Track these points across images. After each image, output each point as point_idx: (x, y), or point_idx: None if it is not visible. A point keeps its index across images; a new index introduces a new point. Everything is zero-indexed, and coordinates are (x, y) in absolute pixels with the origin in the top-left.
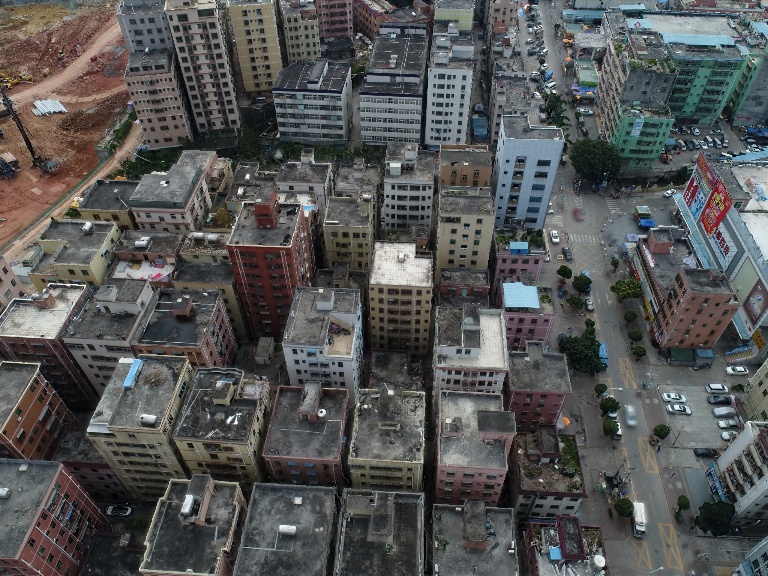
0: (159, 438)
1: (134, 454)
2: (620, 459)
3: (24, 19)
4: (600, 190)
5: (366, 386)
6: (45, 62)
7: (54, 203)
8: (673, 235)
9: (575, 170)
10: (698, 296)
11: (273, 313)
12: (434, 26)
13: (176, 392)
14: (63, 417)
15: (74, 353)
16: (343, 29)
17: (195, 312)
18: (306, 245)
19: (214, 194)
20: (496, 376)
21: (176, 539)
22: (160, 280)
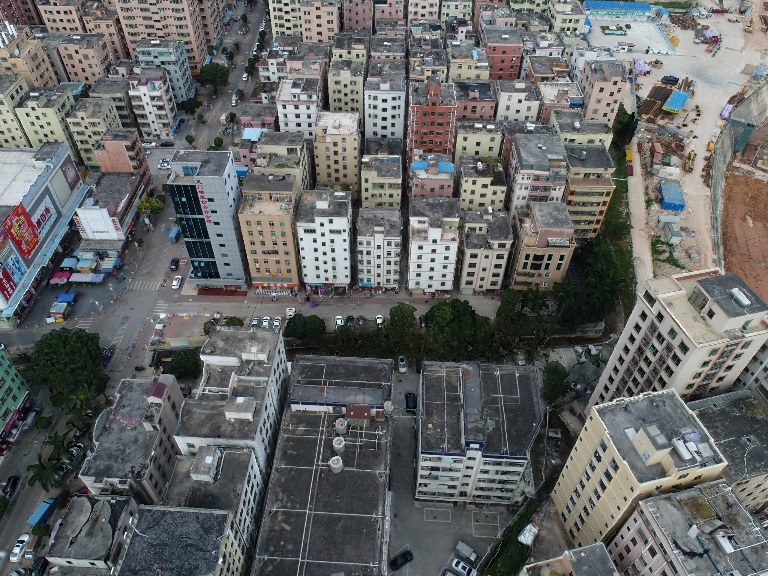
0: None
1: None
2: None
3: None
4: None
5: None
6: None
7: None
8: None
9: None
10: None
11: None
12: (243, 486)
13: None
14: None
15: None
16: None
17: None
18: None
19: None
20: None
21: (431, 43)
22: (506, 123)
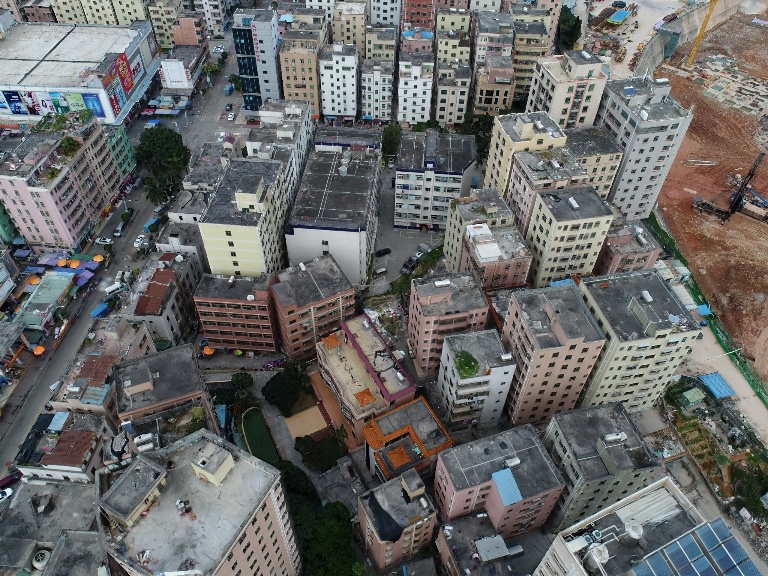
0: None
1: None
2: None
3: None
4: None
5: None
6: None
7: None
8: None
9: None
10: None
11: None
12: (288, 161)
13: None
14: None
15: None
16: None
17: None
18: None
19: None
20: None
21: None
22: None
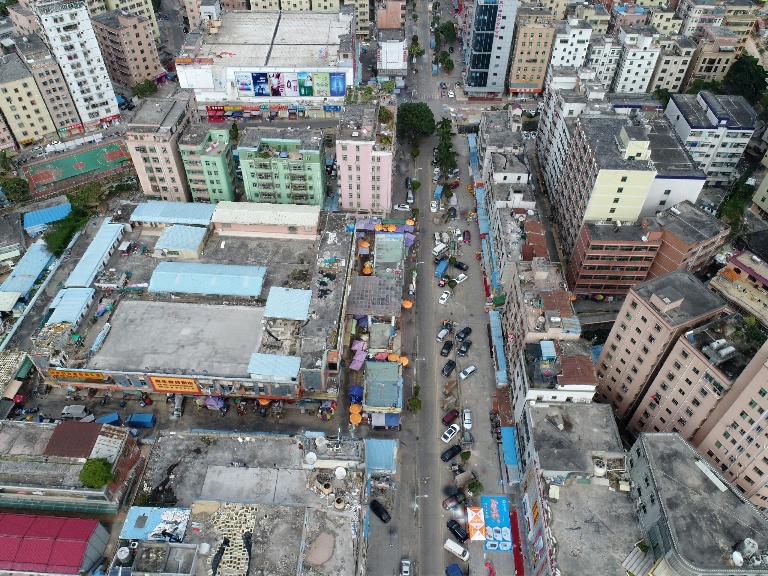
0: None
1: None
2: None
3: None
4: None
5: None
6: None
7: None
8: None
9: None
10: None
11: None
12: None
13: None
14: None
15: None
16: None
17: None
18: None
19: None
20: None
21: None
22: None
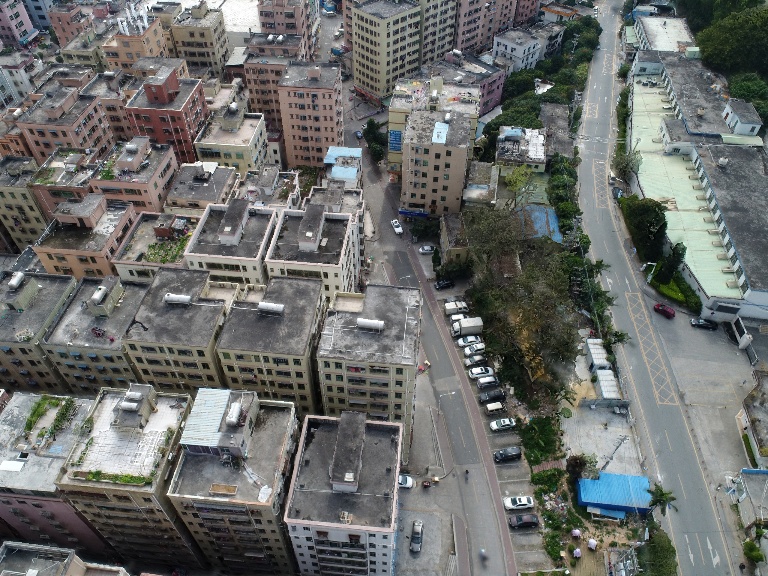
0: None
1: None
2: None
3: None
4: None
5: None
6: None
7: None
8: (112, 7)
9: None
10: (52, 15)
11: None
12: None
13: None
14: None
15: None
16: None
17: None
18: None
19: None
20: None
21: None
22: None
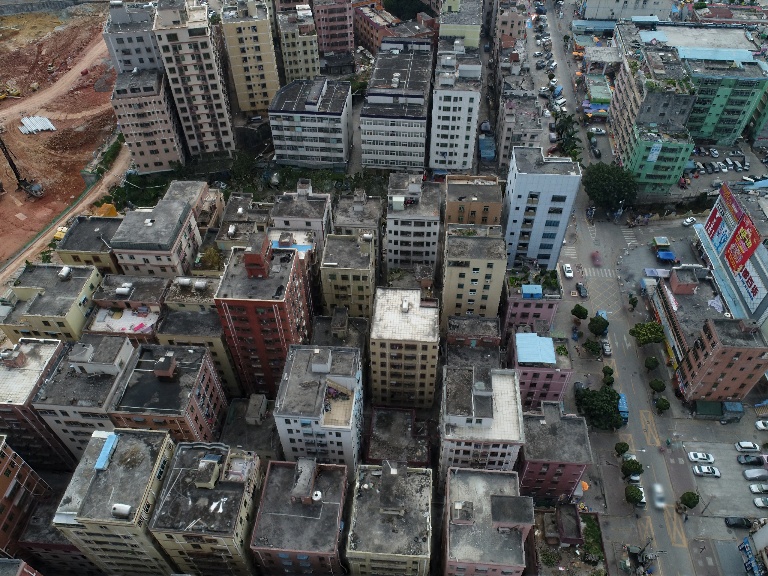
0: (134, 530)
1: (107, 542)
2: (646, 537)
3: (14, 29)
4: (615, 218)
5: (367, 443)
6: (34, 76)
7: (39, 230)
8: (697, 274)
9: (588, 196)
10: (729, 350)
11: (266, 366)
12: (439, 43)
13: (154, 474)
14: (34, 488)
15: (46, 418)
16: (343, 43)
17: (179, 372)
18: (302, 292)
19: (204, 229)
20: (510, 448)
21: None
22: (143, 332)
